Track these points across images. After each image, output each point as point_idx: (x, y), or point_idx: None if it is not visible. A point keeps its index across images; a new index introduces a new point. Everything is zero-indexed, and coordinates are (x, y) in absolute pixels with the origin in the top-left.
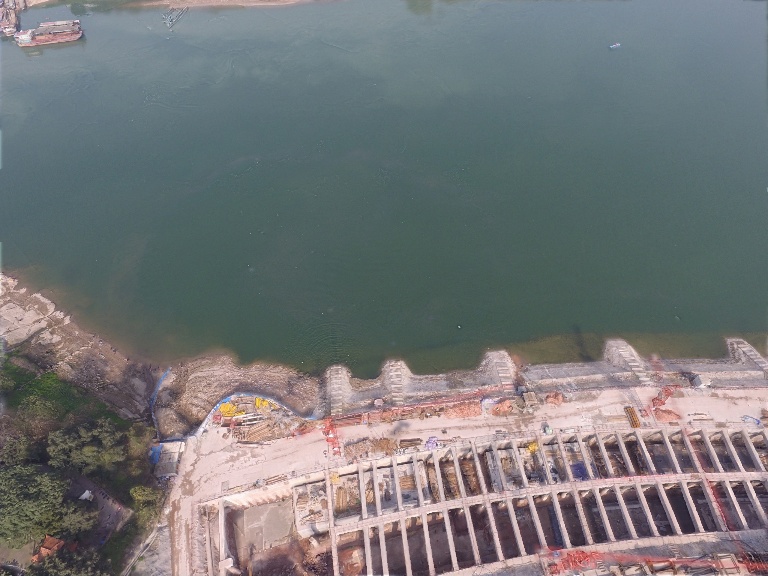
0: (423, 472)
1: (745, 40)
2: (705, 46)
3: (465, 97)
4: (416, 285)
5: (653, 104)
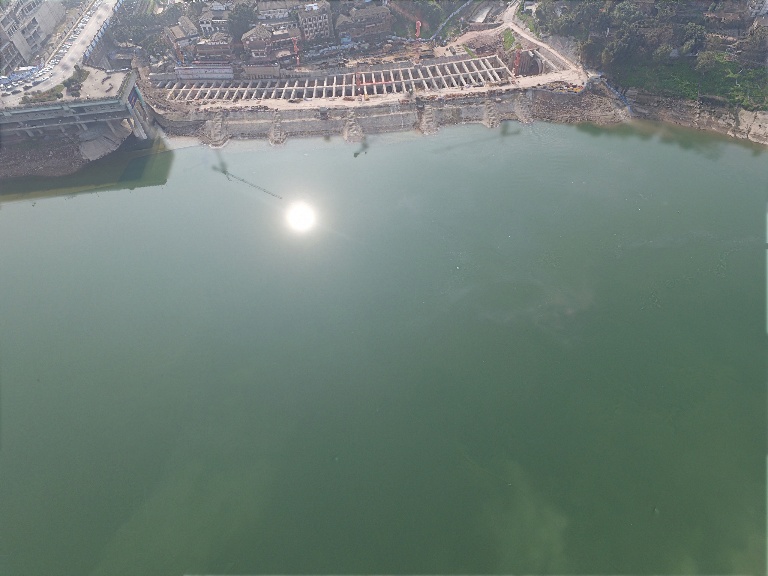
0: None
1: None
2: None
3: (459, 463)
4: (489, 167)
5: (135, 421)
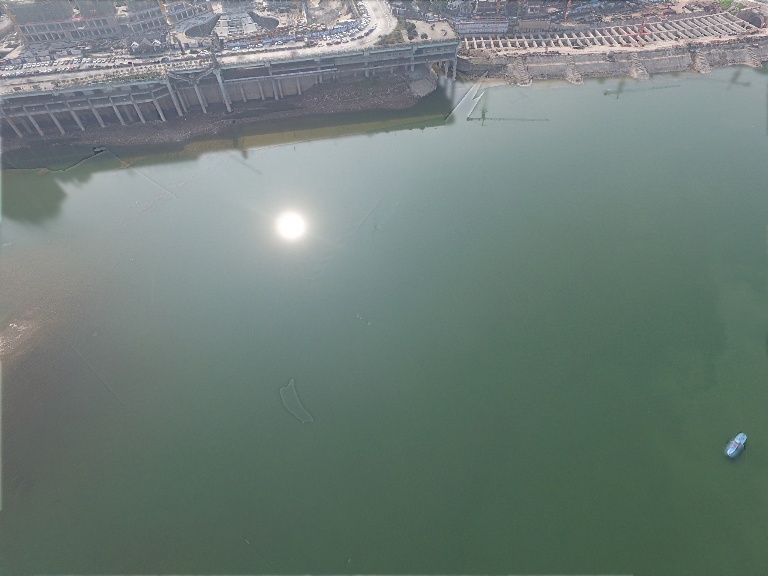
0: None
1: (428, 516)
2: (549, 425)
3: None
4: None
5: (637, 266)
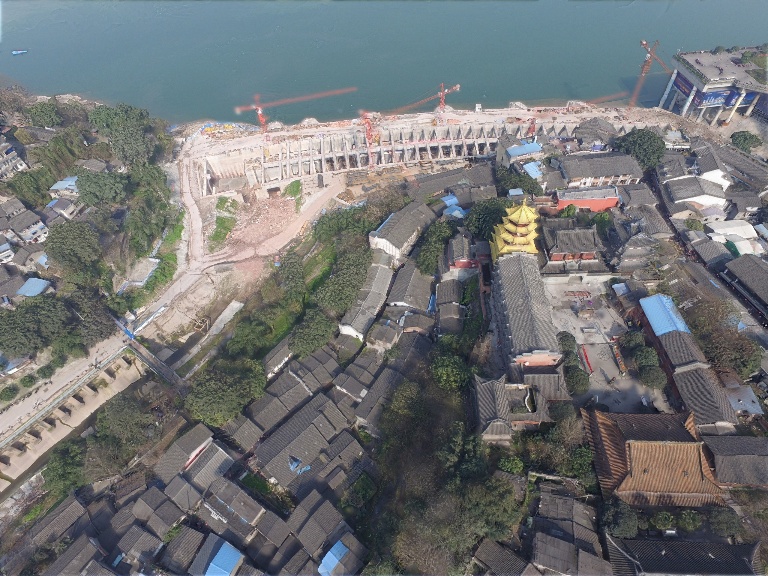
0: (316, 152)
1: None
2: None
3: (384, 3)
4: (329, 90)
5: None
